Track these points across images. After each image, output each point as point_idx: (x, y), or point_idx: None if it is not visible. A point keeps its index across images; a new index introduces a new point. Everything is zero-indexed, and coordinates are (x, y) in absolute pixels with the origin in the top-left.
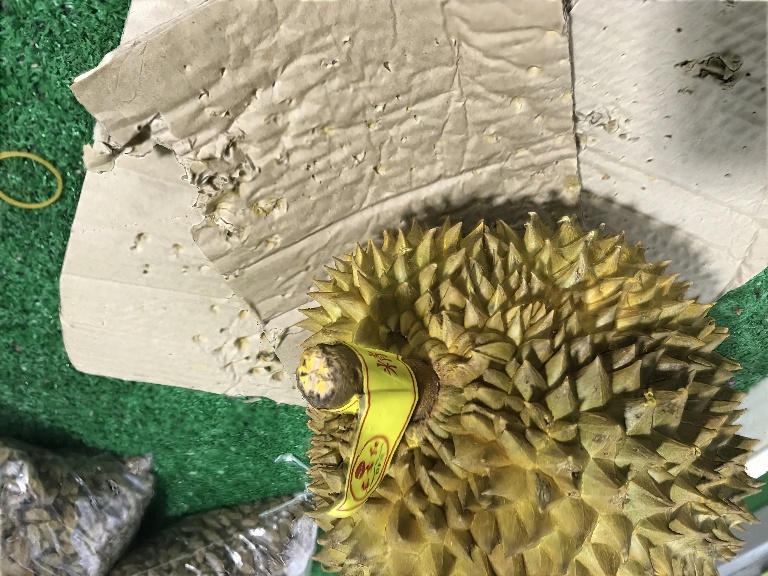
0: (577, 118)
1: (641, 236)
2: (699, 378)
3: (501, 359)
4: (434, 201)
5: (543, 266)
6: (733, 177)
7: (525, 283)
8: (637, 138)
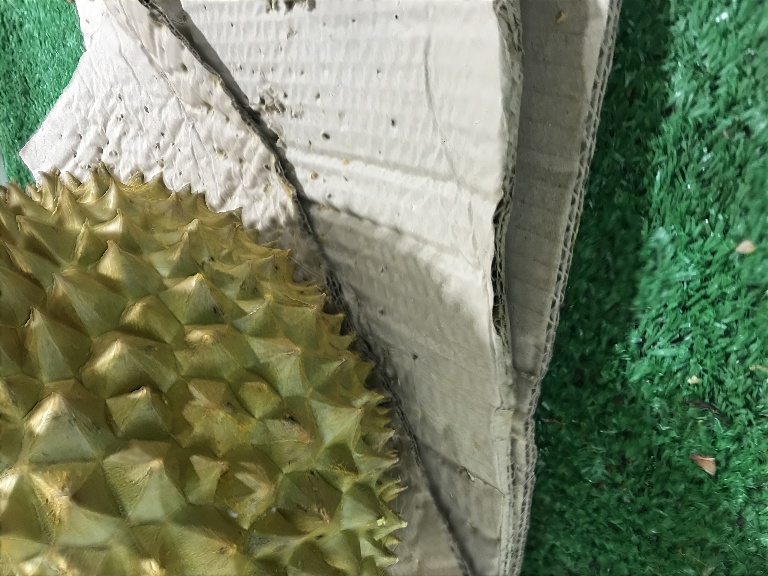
0: None
1: (371, 251)
2: None
3: None
4: None
5: None
6: (399, 123)
7: None
8: None
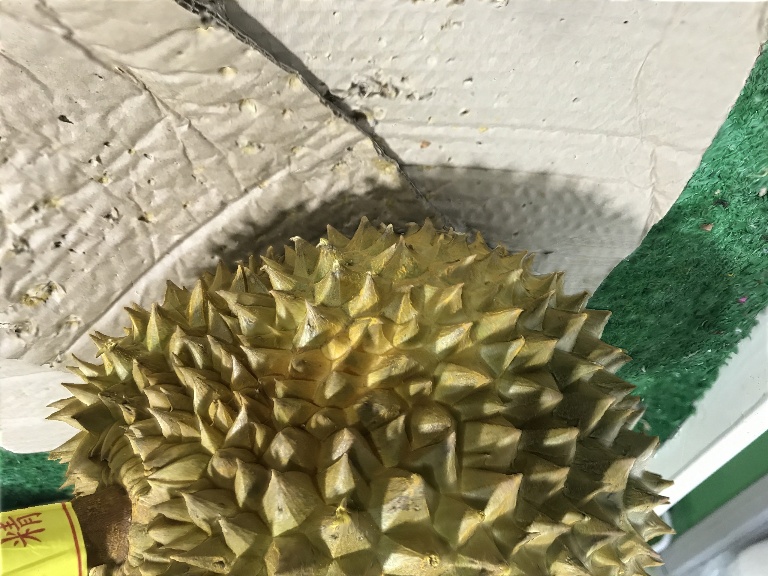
0: (337, 97)
1: (508, 194)
2: (521, 406)
3: (185, 481)
4: (235, 228)
5: (282, 320)
6: (584, 100)
7: (235, 361)
8: (429, 94)
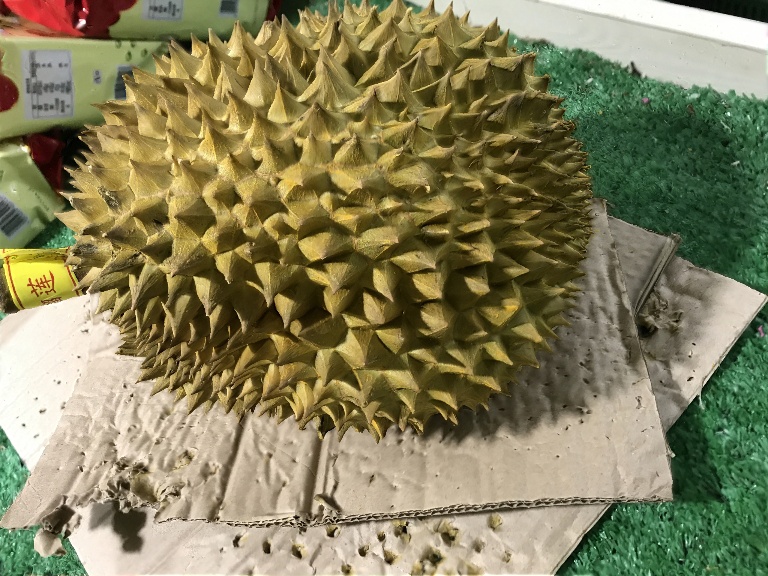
0: None
1: None
2: None
3: None
4: None
5: None
6: None
7: None
8: None
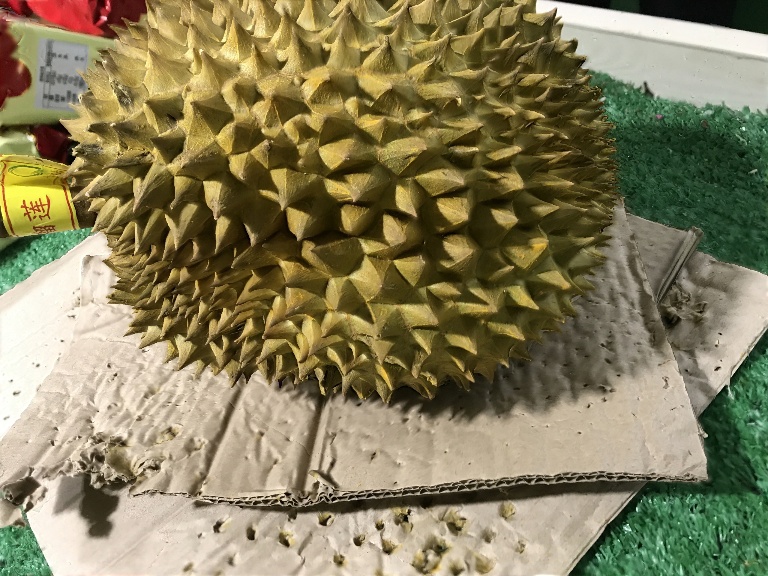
0: None
1: None
2: None
3: None
4: None
5: None
6: None
7: None
8: None
